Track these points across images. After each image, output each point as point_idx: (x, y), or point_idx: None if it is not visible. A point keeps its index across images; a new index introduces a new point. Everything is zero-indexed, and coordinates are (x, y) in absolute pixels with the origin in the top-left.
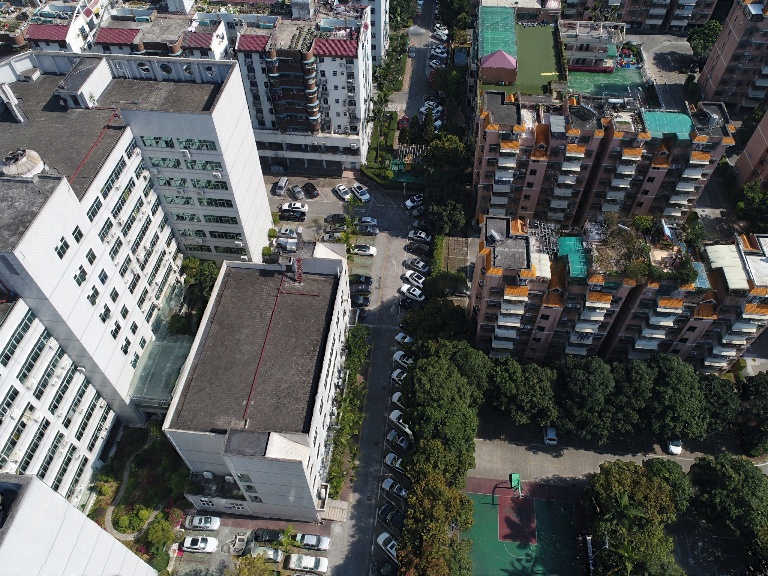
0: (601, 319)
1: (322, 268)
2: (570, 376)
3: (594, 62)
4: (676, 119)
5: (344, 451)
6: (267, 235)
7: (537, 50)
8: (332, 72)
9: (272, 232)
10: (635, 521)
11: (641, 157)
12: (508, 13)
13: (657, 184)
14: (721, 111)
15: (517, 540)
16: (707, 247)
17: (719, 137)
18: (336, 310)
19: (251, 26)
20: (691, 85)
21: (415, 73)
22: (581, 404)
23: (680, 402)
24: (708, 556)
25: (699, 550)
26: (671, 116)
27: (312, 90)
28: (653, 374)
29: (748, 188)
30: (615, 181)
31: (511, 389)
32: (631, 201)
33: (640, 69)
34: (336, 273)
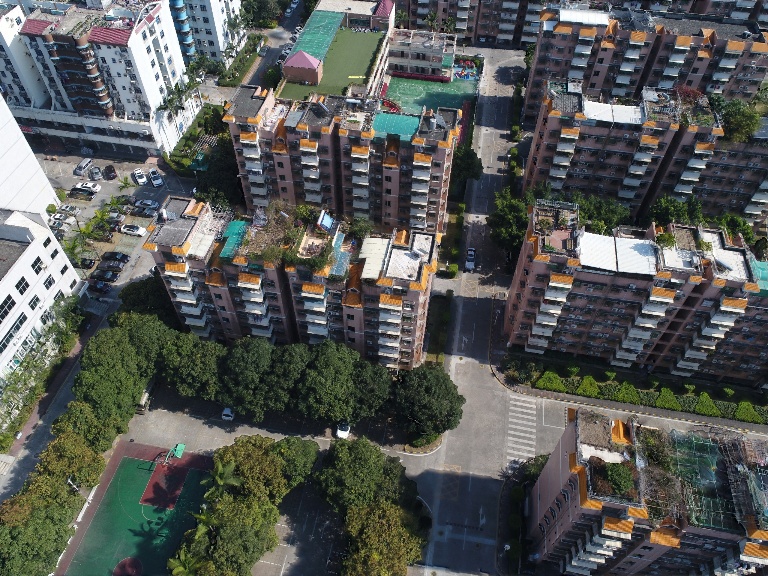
0: (260, 301)
1: (16, 235)
2: (231, 353)
3: (431, 71)
4: (405, 121)
5: (32, 411)
6: (45, 210)
7: (356, 54)
8: (111, 59)
9: (50, 207)
10: (240, 491)
11: (371, 156)
12: (336, 18)
13: (396, 184)
14: (455, 117)
15: (156, 504)
16: (365, 239)
17: (435, 140)
18: (13, 274)
19: (45, 12)
20: (514, 98)
21: (259, 71)
22: (238, 381)
23: (320, 384)
24: (329, 534)
25: (324, 528)
26: (402, 118)
27: (93, 75)
28: (311, 357)
29: (499, 195)
30: (354, 178)
31: (174, 361)
32: (380, 200)
33: (478, 81)
34: (30, 241)
